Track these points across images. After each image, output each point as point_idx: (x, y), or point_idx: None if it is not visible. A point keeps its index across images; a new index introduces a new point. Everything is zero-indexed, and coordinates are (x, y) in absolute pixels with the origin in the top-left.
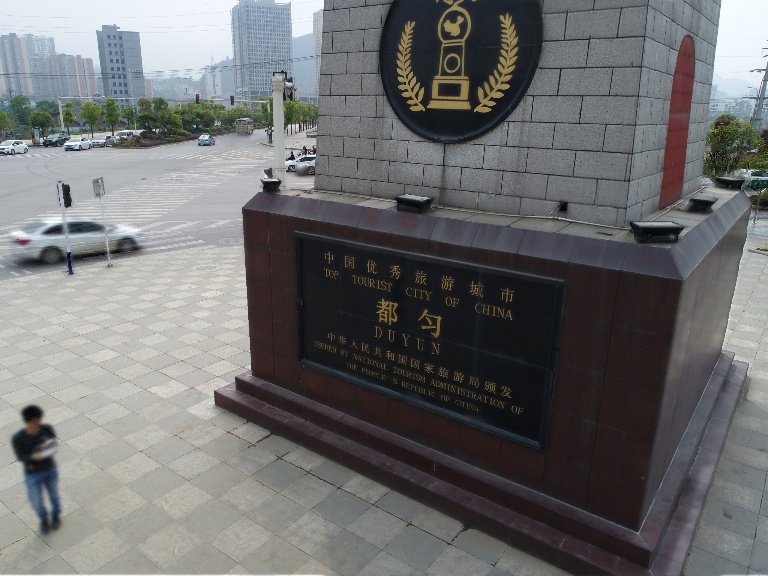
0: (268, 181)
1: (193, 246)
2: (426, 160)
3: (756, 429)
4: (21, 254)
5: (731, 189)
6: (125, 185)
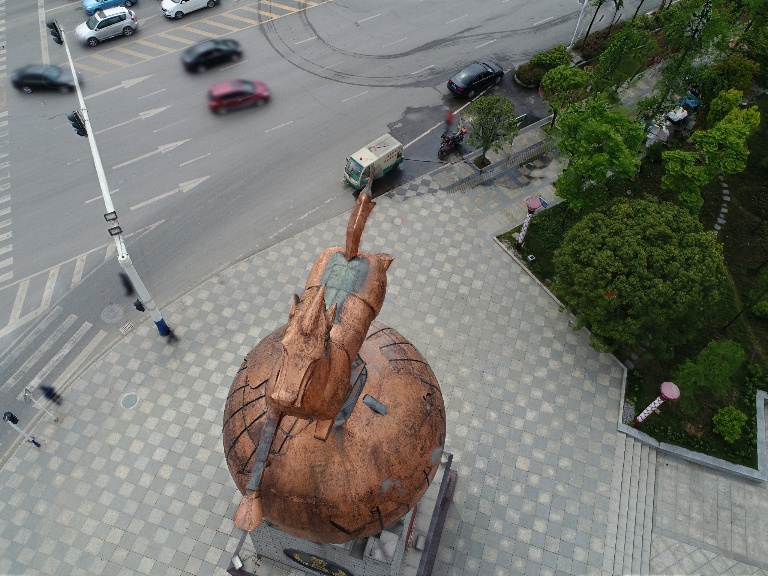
0: None
1: (88, 339)
2: (313, 571)
3: (451, 530)
4: None
5: (442, 465)
6: None
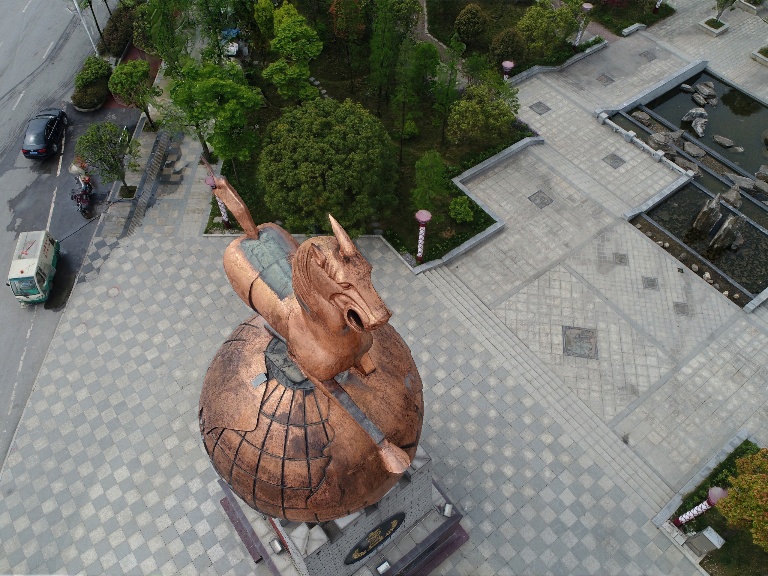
0: None
1: None
2: None
3: None
4: None
5: None
6: None
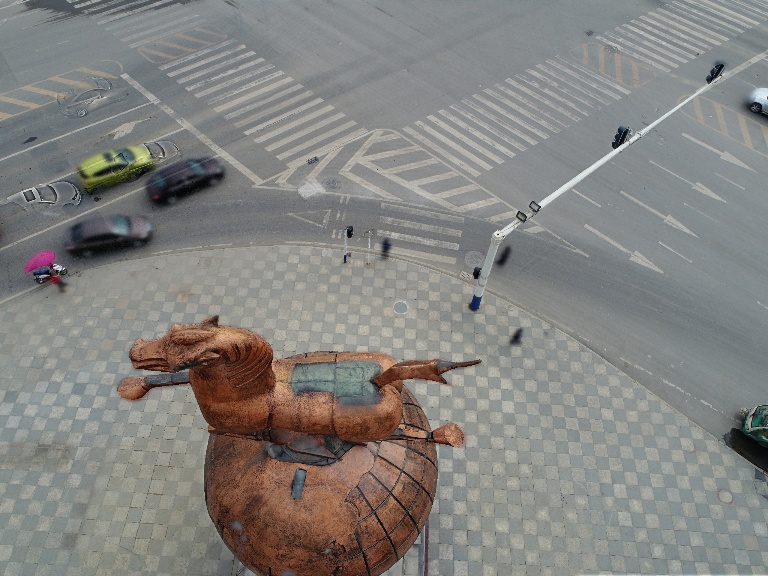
0: None
1: (444, 252)
2: None
3: None
4: (359, 201)
5: None
6: (552, 53)
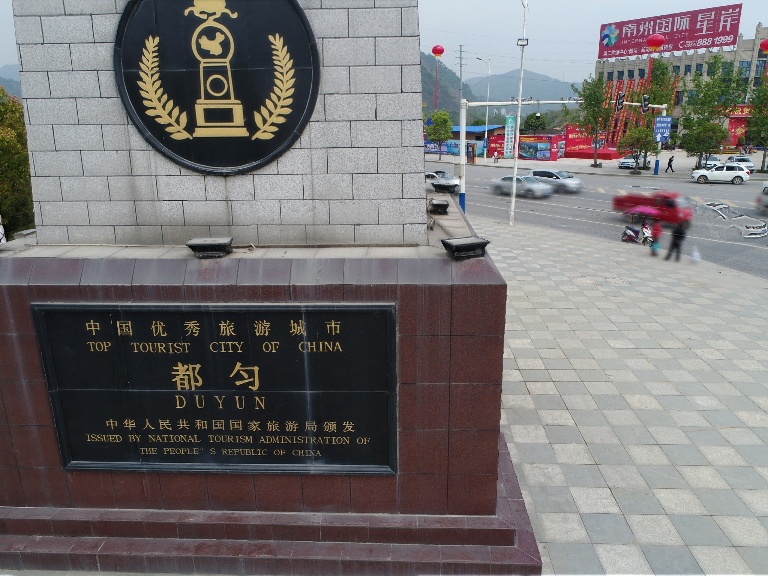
0: None
1: None
2: None
3: None
4: None
5: None
6: None
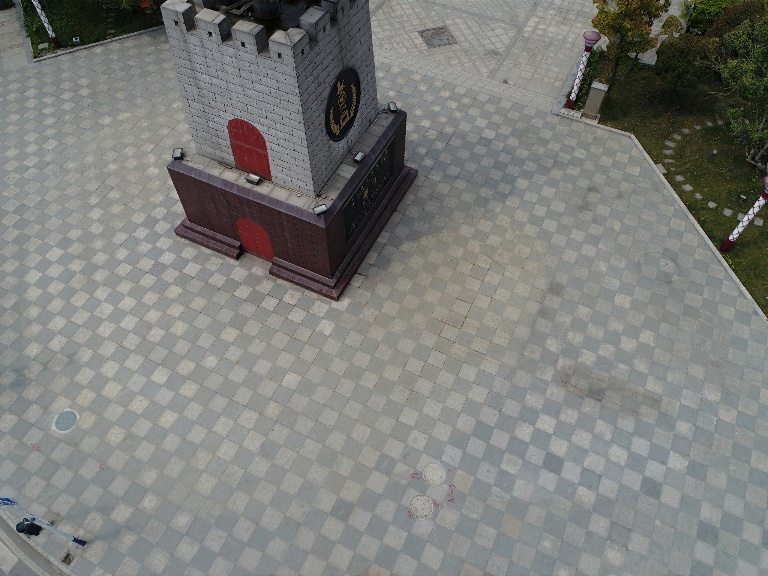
0: (327, 208)
1: None
2: None
3: None
4: None
5: None
6: None
